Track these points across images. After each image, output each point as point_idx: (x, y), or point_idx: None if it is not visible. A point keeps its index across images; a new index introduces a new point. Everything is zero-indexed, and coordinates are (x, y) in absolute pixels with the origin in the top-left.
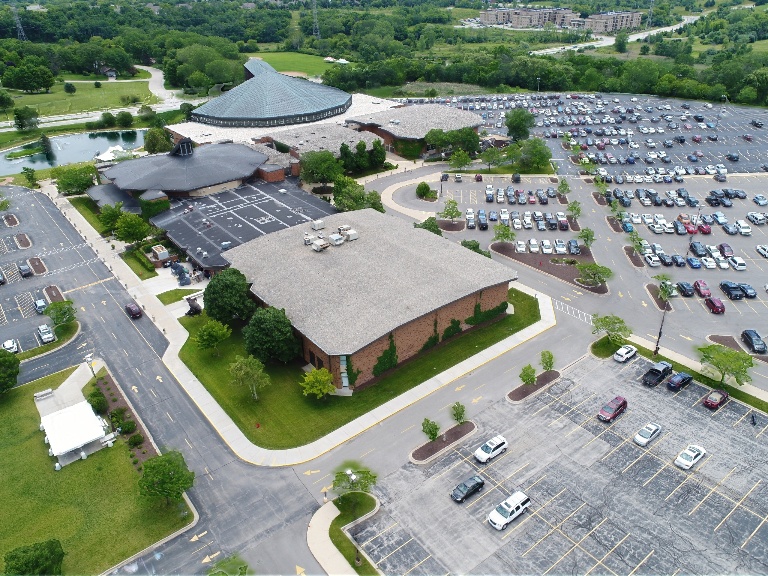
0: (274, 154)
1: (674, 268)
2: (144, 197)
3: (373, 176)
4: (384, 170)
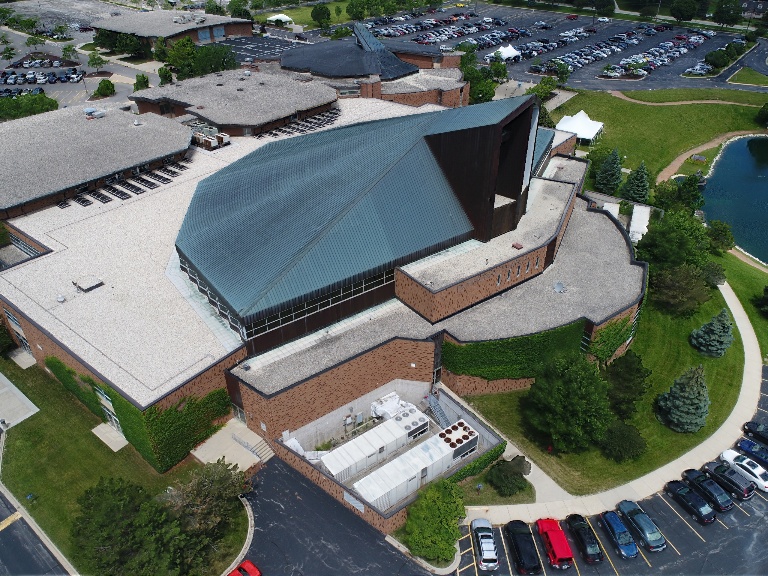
0: (280, 73)
1: None
2: None
3: None
4: None
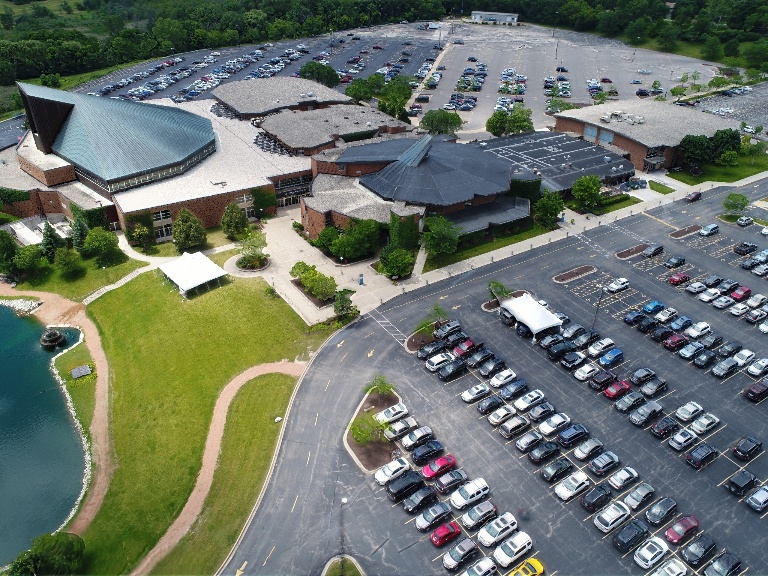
0: (385, 139)
1: None
2: (535, 178)
3: None
4: None
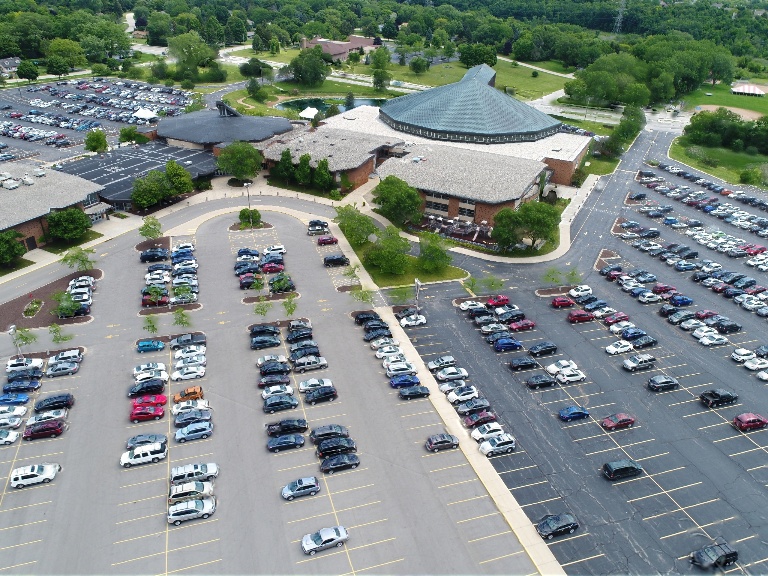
0: None
1: (2, 386)
2: None
3: (301, 194)
4: (325, 196)
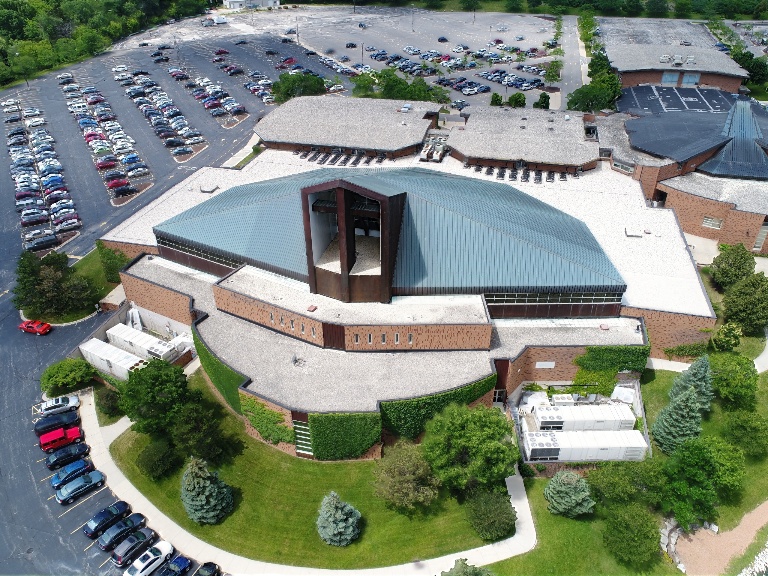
0: (609, 128)
1: None
2: None
3: None
4: None
